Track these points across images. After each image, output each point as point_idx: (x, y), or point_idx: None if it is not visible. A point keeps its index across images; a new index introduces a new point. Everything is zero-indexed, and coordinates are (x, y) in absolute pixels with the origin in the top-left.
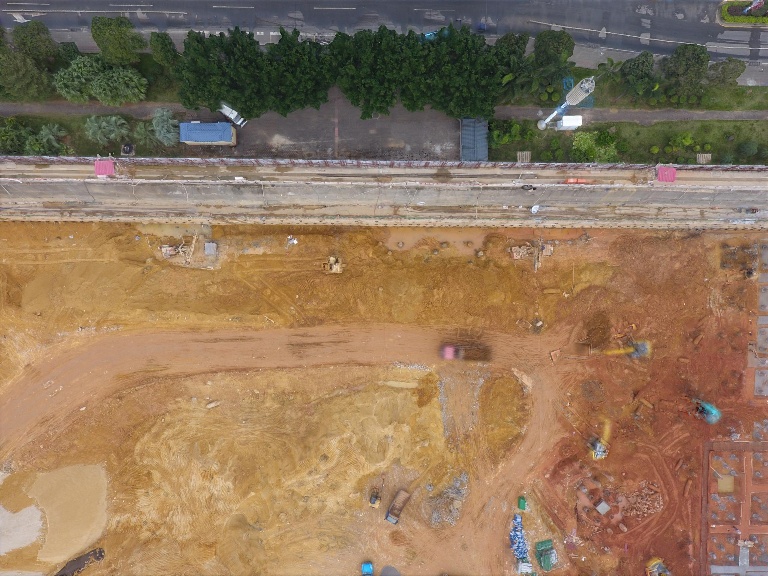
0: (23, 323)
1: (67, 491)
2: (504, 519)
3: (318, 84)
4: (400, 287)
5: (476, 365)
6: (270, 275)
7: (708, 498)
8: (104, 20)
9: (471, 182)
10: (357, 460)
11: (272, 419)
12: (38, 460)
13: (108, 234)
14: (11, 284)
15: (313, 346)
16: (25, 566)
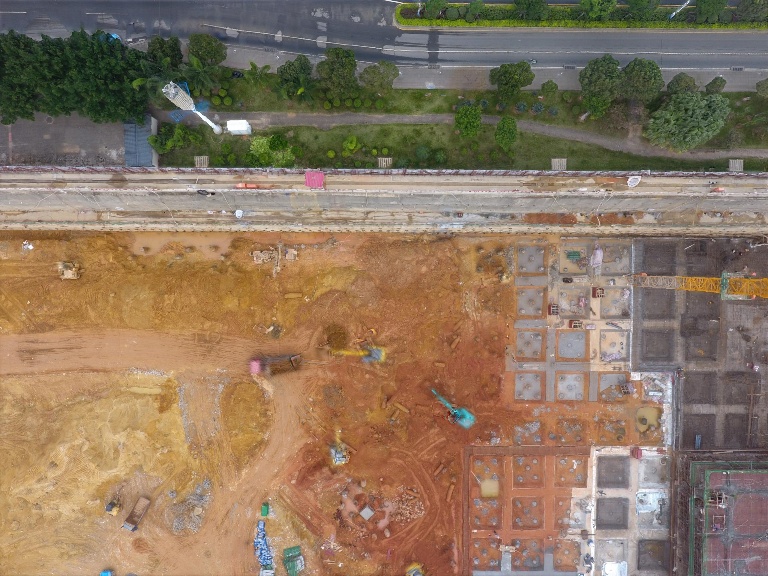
0: None
1: None
2: (249, 526)
3: None
4: (130, 292)
5: (215, 371)
6: (5, 281)
7: (470, 503)
8: None
9: (141, 187)
10: (86, 467)
11: (12, 426)
12: None
13: None
14: None
15: (44, 352)
16: None
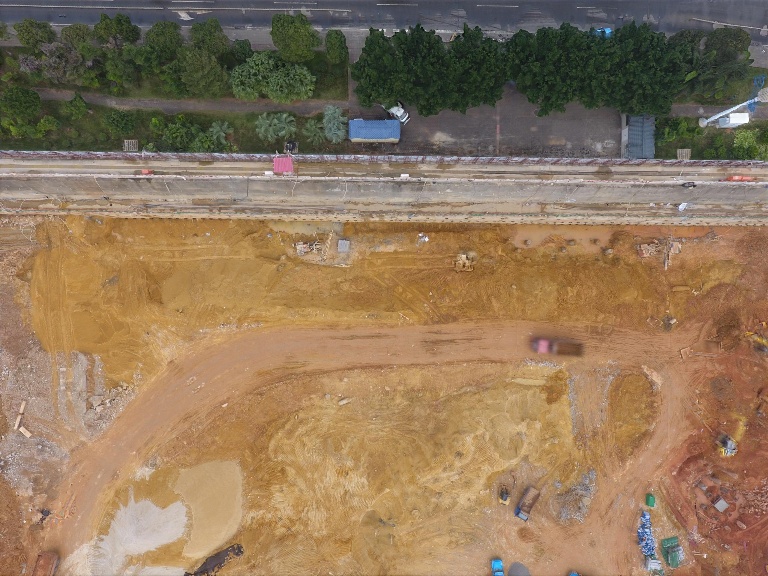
0: (166, 320)
1: (208, 487)
2: (632, 516)
3: (495, 81)
4: (534, 284)
5: (606, 362)
6: (402, 272)
7: None
8: (287, 17)
9: (635, 179)
10: (492, 457)
11: (401, 416)
12: (181, 456)
13: (244, 231)
14: (150, 281)
15: (446, 343)
16: (171, 561)
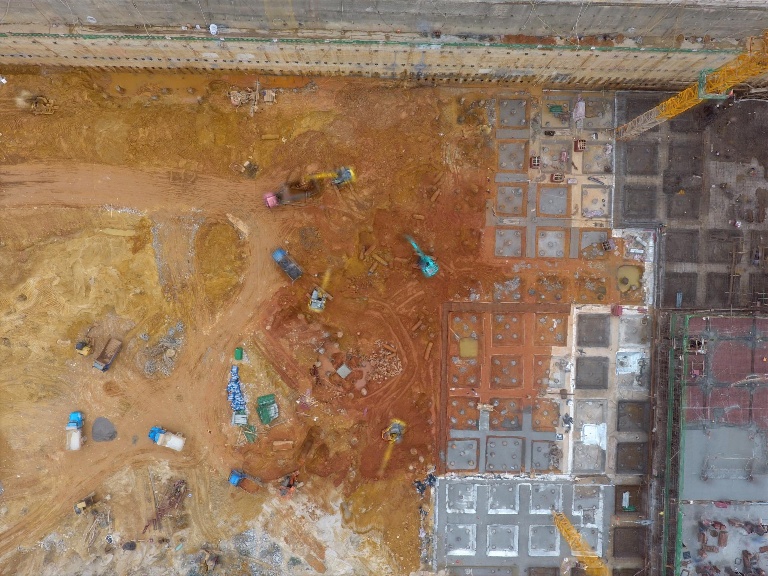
0: None
1: None
2: (222, 371)
3: None
4: (104, 125)
5: (190, 210)
6: None
7: (448, 361)
8: None
9: None
10: (57, 301)
11: None
12: None
13: None
14: None
15: (16, 185)
16: None
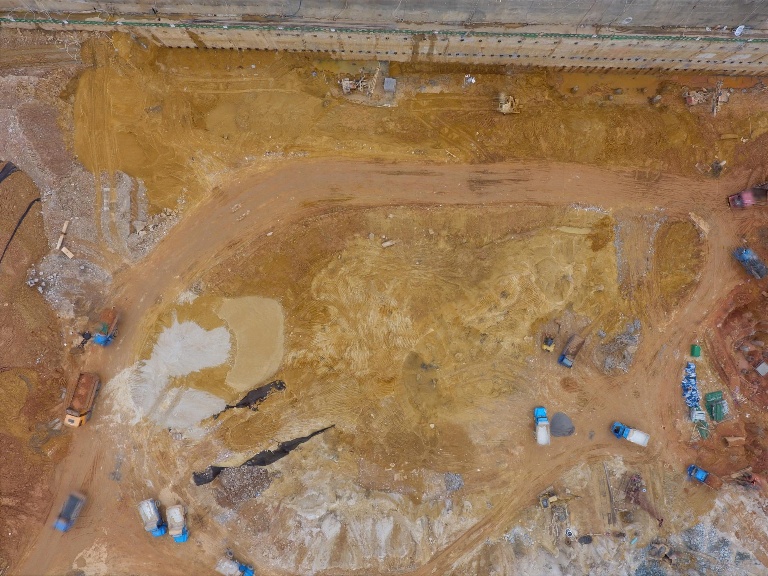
0: (211, 145)
1: (251, 318)
2: (676, 367)
3: None
4: (583, 124)
5: (653, 209)
6: (448, 114)
7: None
8: None
9: None
10: (538, 297)
11: (445, 262)
12: (225, 283)
13: (290, 65)
14: (194, 111)
15: (493, 183)
16: (214, 388)
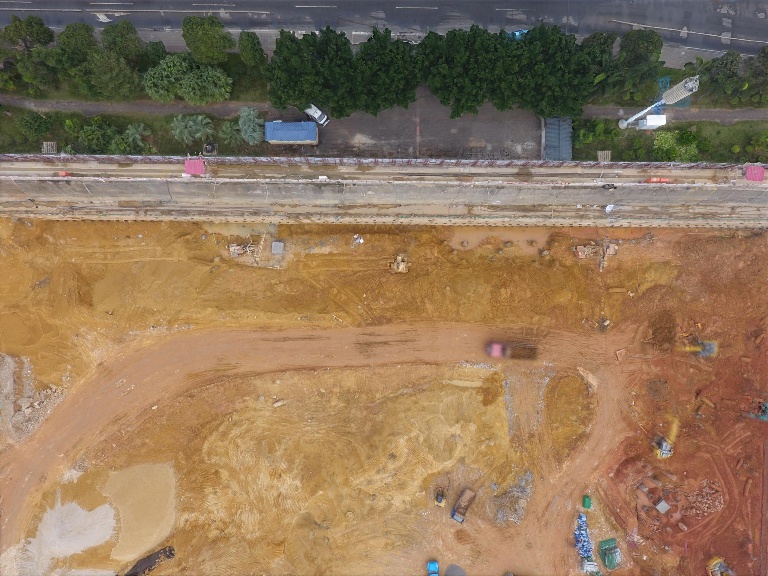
0: (95, 322)
1: (138, 489)
2: (568, 518)
3: (407, 83)
4: (468, 286)
5: (542, 364)
6: (336, 274)
7: None
8: (196, 19)
9: (553, 181)
10: (425, 459)
11: (337, 418)
12: (111, 458)
13: (177, 233)
14: (81, 283)
15: (380, 345)
16: (99, 564)
